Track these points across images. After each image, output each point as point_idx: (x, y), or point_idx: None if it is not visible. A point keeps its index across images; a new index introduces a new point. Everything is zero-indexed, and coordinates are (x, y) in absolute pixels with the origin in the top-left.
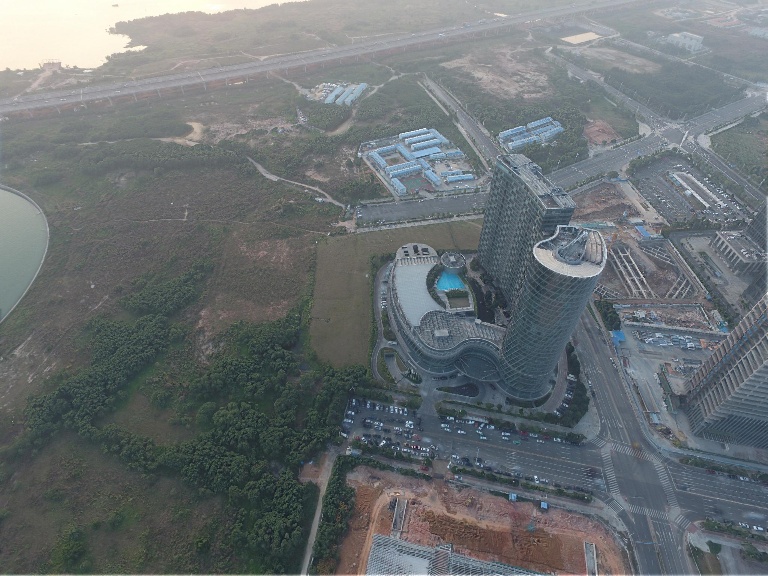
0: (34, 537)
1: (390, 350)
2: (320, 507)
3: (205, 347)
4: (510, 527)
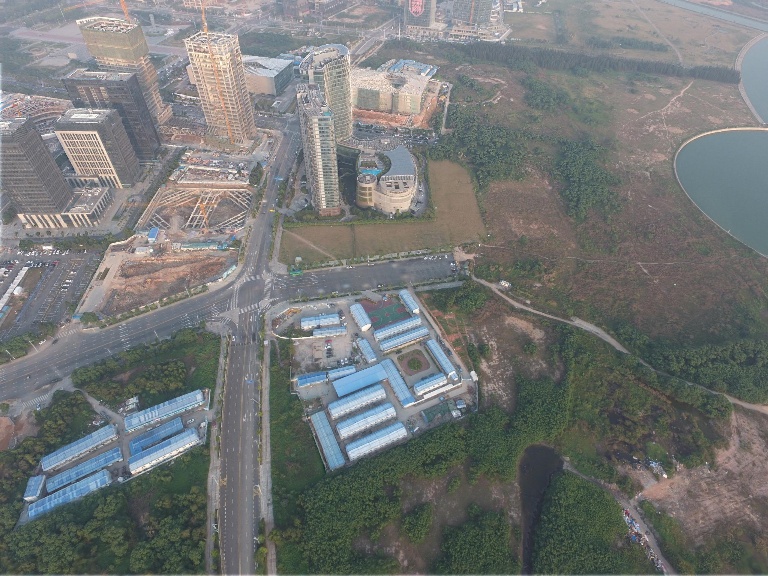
0: (554, 122)
1: None
2: (443, 124)
3: (533, 171)
4: (364, 119)
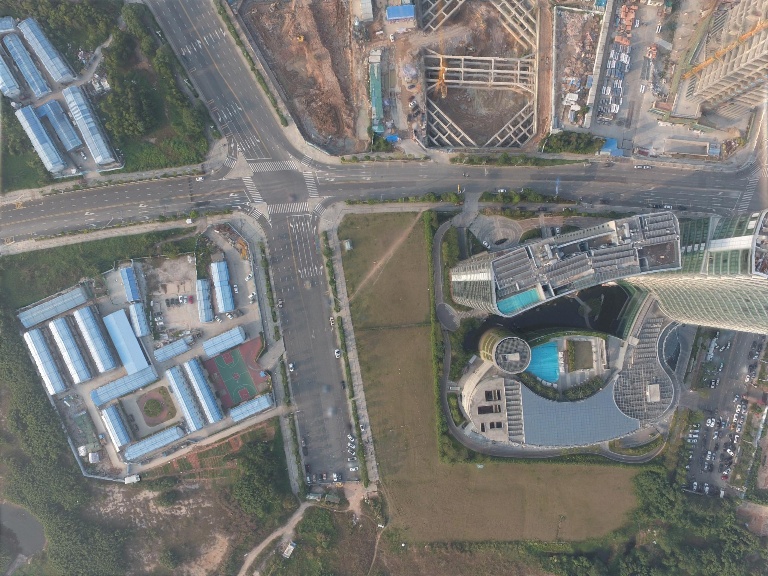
0: None
1: (617, 440)
2: None
3: None
4: None
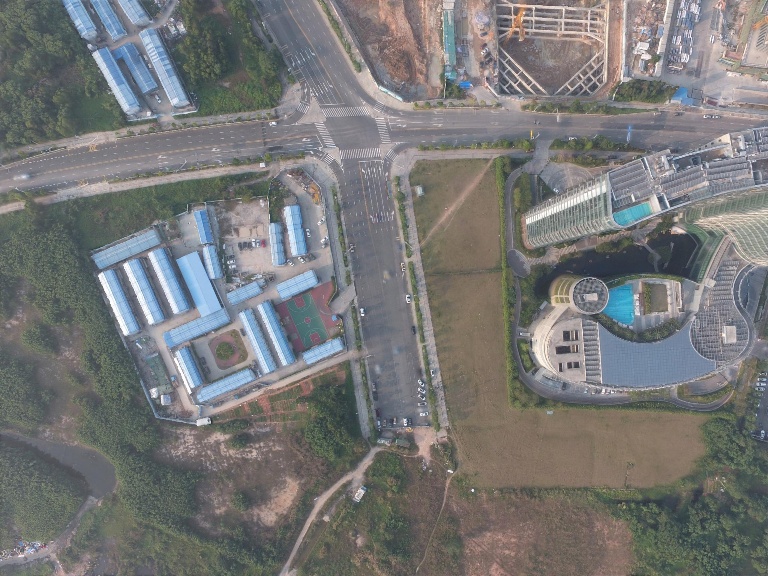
0: None
1: (686, 387)
2: None
3: None
4: None
